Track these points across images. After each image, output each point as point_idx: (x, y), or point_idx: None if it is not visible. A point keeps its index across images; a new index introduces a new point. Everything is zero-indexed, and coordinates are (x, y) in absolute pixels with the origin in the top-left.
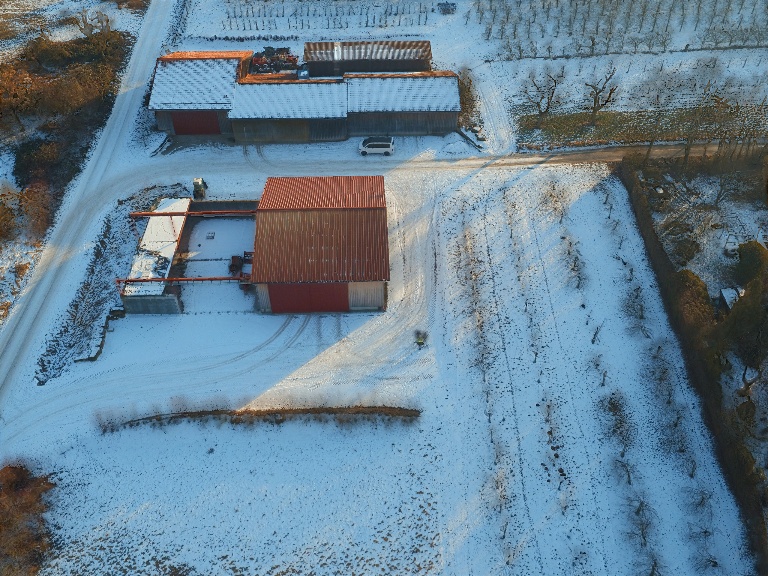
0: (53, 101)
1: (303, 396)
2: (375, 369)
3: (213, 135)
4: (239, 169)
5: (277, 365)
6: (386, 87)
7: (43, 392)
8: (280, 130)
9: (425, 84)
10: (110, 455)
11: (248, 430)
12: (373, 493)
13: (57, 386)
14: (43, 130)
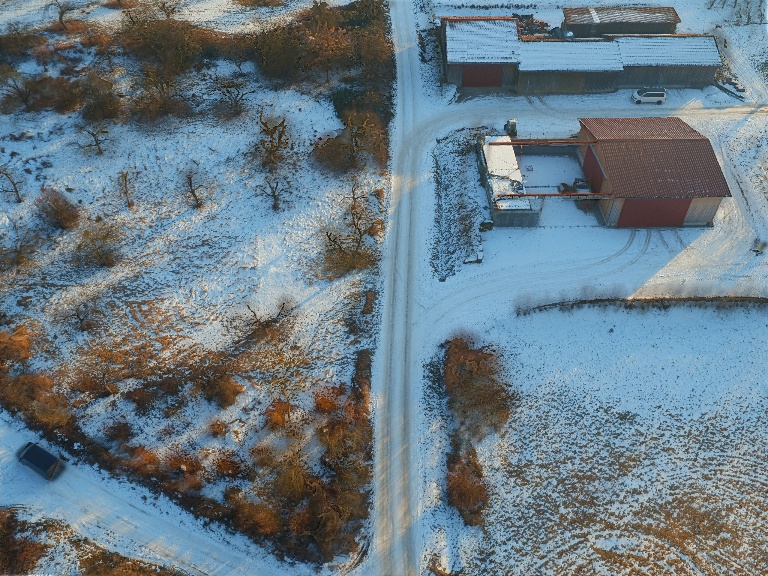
0: (367, 54)
1: (676, 289)
2: (727, 269)
3: (494, 87)
4: (532, 115)
5: (642, 266)
6: (652, 45)
7: (448, 286)
8: (559, 82)
9: (686, 43)
10: (527, 333)
11: (640, 314)
12: (765, 361)
13: (457, 282)
14: (345, 82)
